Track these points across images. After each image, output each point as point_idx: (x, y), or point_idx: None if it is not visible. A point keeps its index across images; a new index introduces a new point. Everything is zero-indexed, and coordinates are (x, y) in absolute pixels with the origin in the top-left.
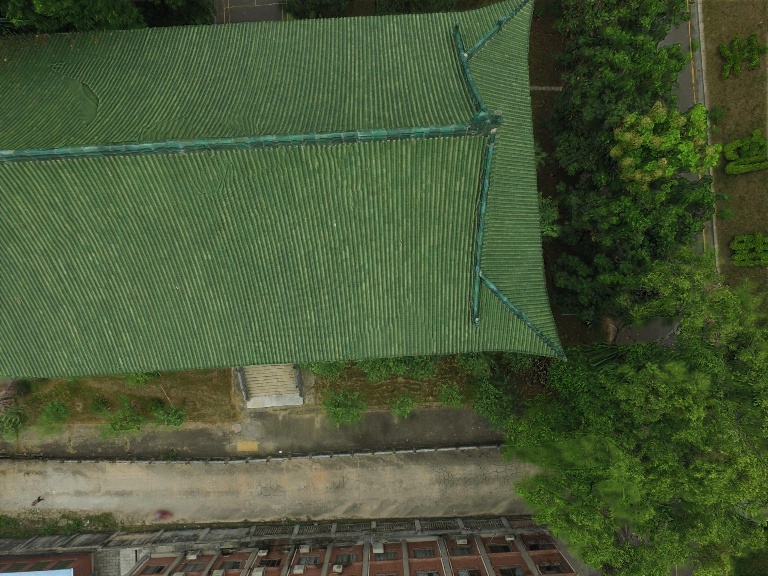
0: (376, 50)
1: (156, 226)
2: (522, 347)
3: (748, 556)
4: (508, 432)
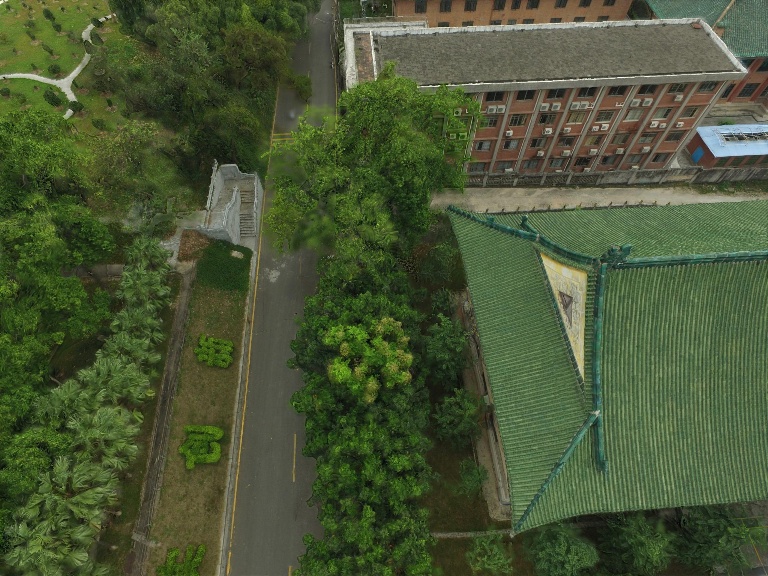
0: (683, 440)
1: None
2: None
3: (258, 164)
4: (430, 227)
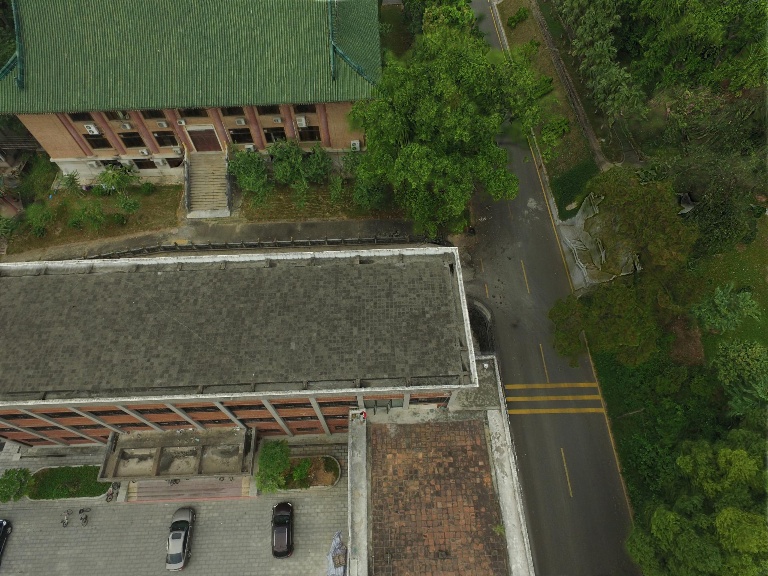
0: None
1: (157, 8)
2: (364, 96)
3: None
4: None
